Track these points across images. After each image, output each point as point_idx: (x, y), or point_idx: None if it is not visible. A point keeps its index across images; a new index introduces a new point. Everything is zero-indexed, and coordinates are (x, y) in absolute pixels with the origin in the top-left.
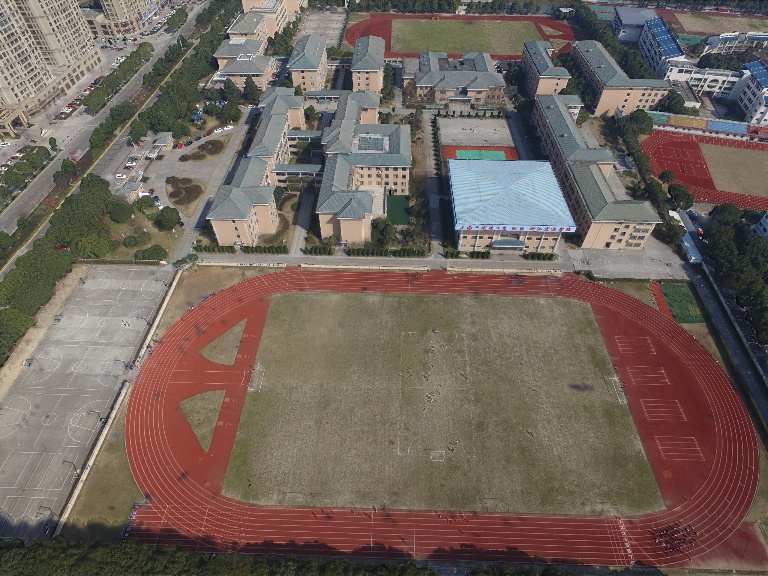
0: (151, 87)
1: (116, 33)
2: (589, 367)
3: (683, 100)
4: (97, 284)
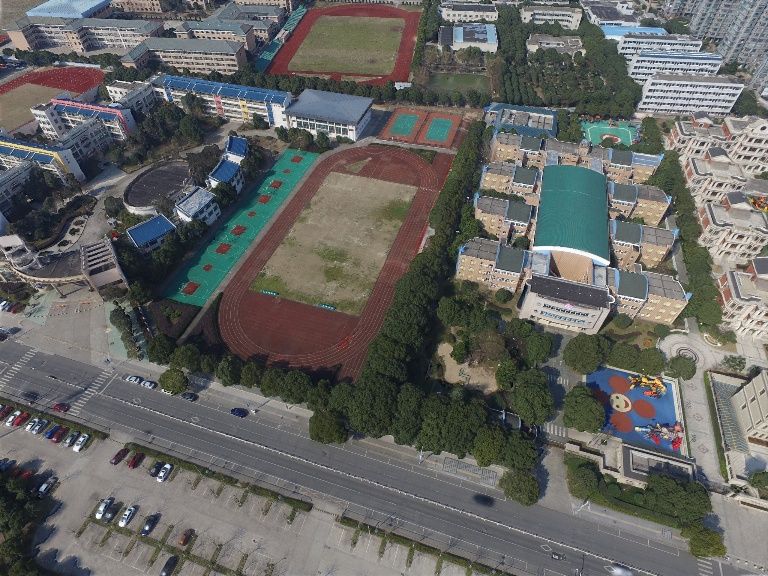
0: None
1: None
2: None
3: (115, 77)
4: None
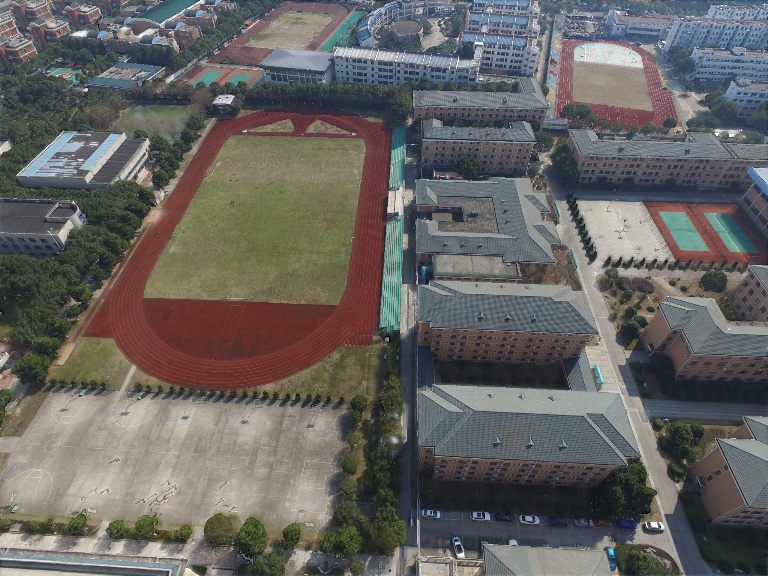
0: None
1: None
2: None
3: None
4: None
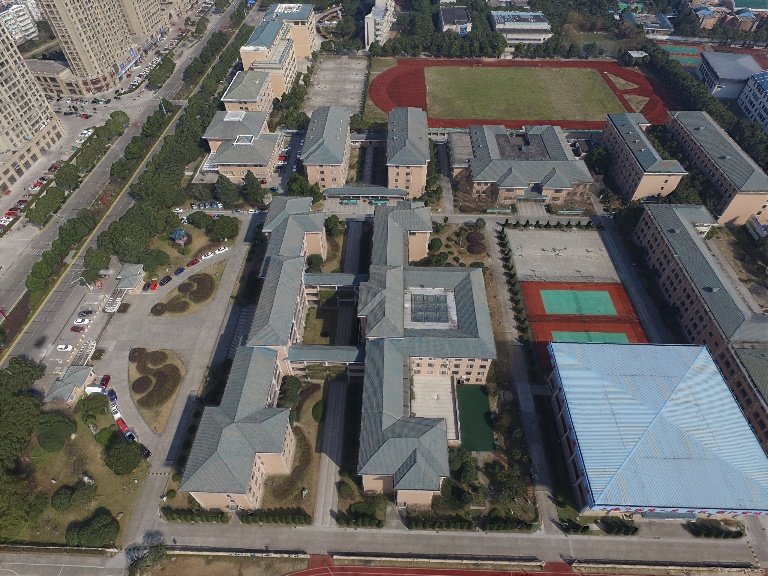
0: (121, 179)
1: (85, 92)
2: None
3: None
4: None
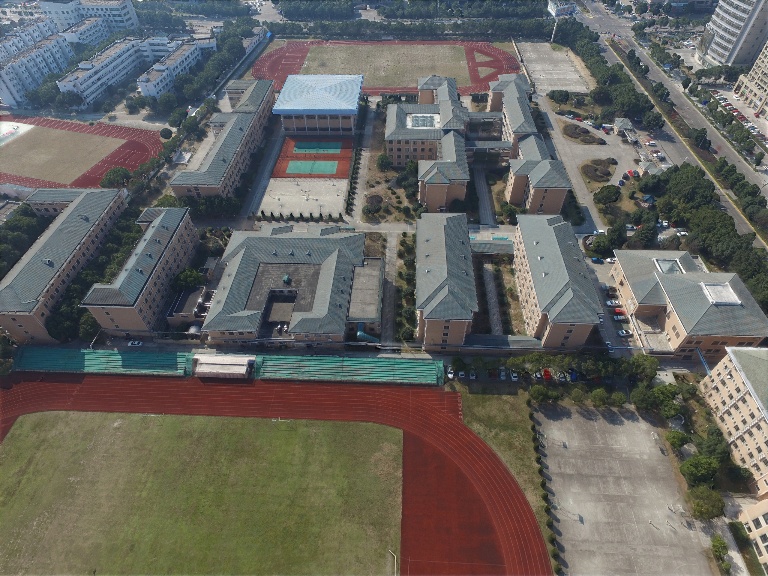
0: None
1: None
2: (313, 68)
3: None
4: (578, 88)
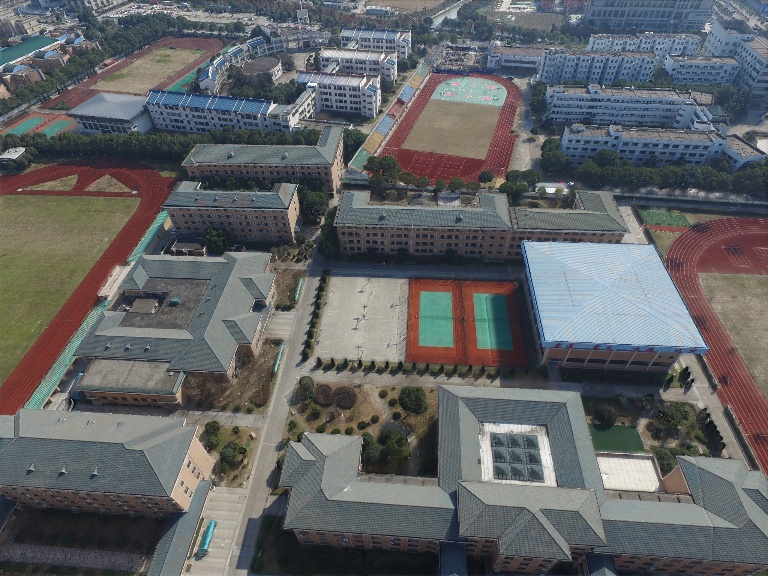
0: None
1: None
2: None
3: None
4: None
